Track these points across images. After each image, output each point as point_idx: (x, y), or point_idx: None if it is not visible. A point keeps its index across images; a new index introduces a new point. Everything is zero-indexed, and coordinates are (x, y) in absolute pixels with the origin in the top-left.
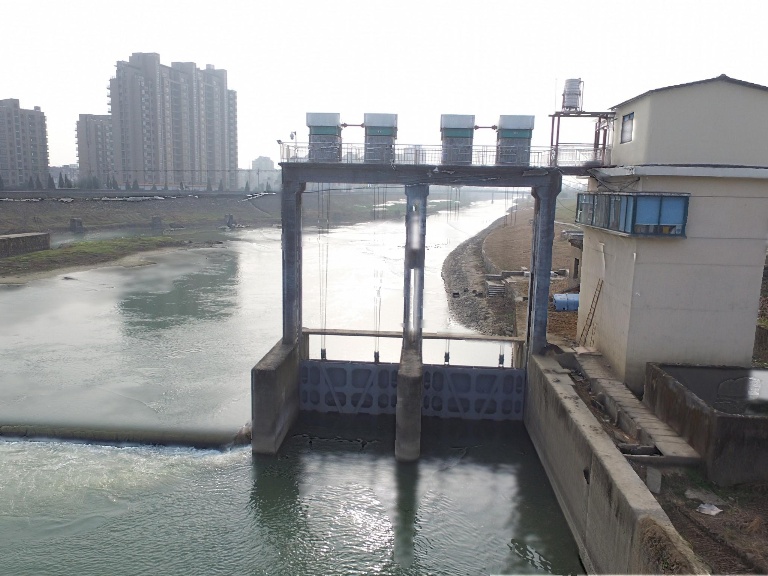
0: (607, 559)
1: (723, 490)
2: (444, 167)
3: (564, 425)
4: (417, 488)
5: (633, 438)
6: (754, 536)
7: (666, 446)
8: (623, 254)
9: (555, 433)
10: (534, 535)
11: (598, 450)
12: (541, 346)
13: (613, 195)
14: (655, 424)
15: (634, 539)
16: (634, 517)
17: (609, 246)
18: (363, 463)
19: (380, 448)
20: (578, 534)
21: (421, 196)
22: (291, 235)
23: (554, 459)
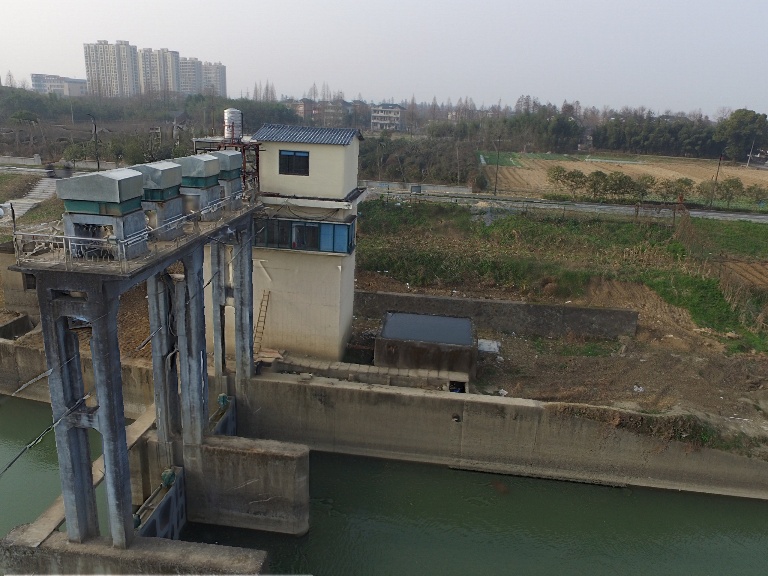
0: (505, 446)
1: (481, 382)
2: (229, 225)
3: (392, 405)
4: (310, 545)
5: (425, 386)
6: (524, 390)
7: (456, 378)
8: (316, 267)
9: (368, 418)
10: (416, 484)
11: (465, 399)
12: (254, 368)
13: (304, 222)
14: (422, 372)
15: (543, 419)
16: (541, 410)
17: (280, 262)
18: (296, 566)
19: (263, 549)
20: (444, 458)
21: (201, 263)
22: (119, 383)
23: (370, 436)
